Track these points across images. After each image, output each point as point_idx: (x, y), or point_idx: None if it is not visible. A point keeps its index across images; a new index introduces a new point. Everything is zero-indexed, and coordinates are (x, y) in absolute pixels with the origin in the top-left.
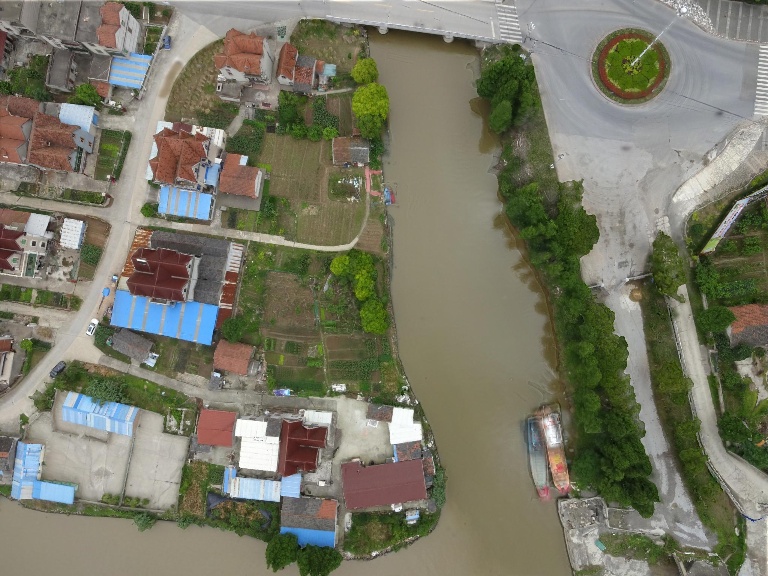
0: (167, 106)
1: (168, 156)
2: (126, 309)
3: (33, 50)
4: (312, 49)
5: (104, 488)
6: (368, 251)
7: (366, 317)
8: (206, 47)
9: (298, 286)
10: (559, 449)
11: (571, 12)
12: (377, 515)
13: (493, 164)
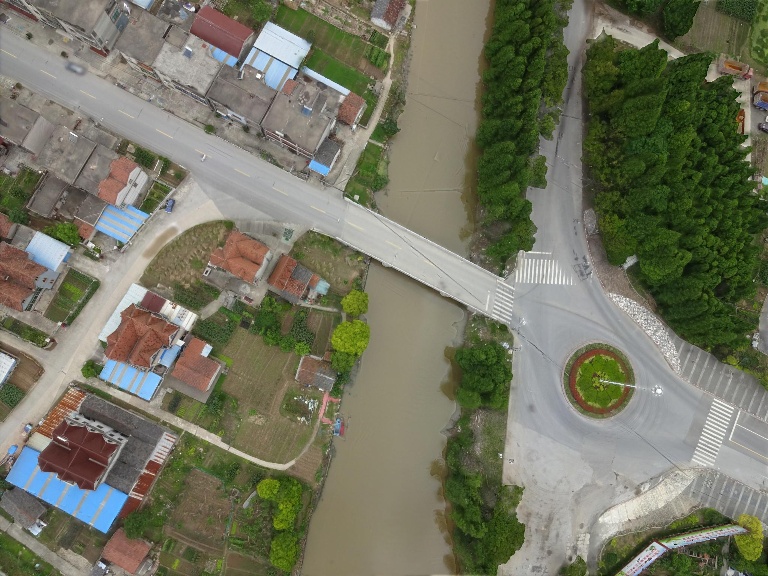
0: (147, 268)
1: (129, 335)
2: (28, 469)
3: (27, 161)
4: (312, 259)
5: None
6: (301, 477)
7: (276, 552)
8: (208, 223)
9: (219, 492)
10: None
11: (562, 311)
12: None
13: (448, 426)
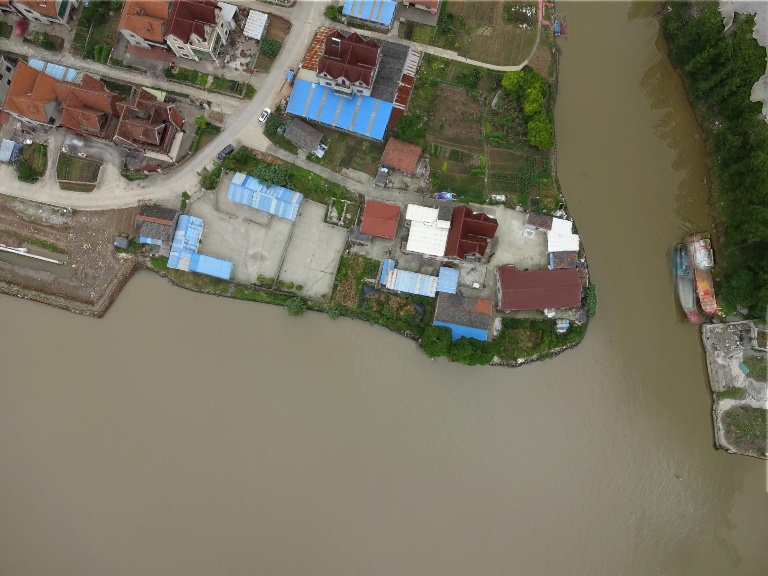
0: None
1: None
2: (303, 98)
3: None
4: None
5: (258, 272)
6: None
7: (536, 127)
8: None
9: (466, 99)
10: (706, 276)
11: None
12: (528, 320)
13: (658, 10)
